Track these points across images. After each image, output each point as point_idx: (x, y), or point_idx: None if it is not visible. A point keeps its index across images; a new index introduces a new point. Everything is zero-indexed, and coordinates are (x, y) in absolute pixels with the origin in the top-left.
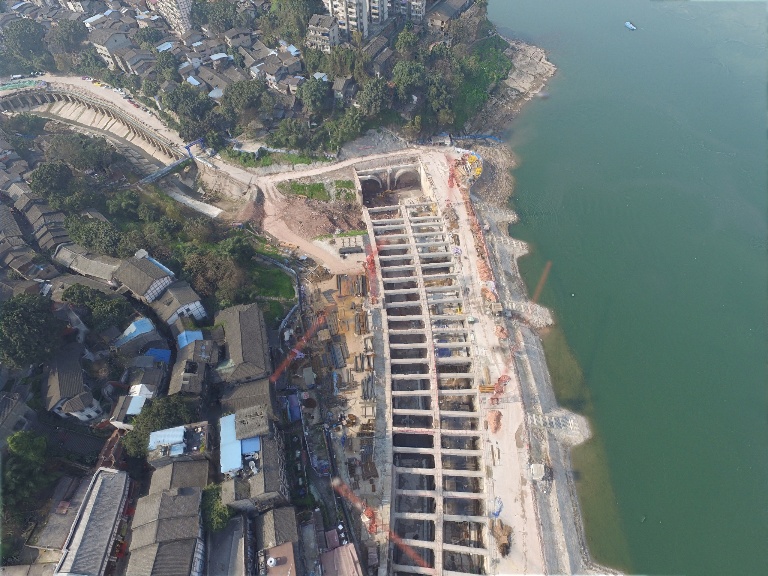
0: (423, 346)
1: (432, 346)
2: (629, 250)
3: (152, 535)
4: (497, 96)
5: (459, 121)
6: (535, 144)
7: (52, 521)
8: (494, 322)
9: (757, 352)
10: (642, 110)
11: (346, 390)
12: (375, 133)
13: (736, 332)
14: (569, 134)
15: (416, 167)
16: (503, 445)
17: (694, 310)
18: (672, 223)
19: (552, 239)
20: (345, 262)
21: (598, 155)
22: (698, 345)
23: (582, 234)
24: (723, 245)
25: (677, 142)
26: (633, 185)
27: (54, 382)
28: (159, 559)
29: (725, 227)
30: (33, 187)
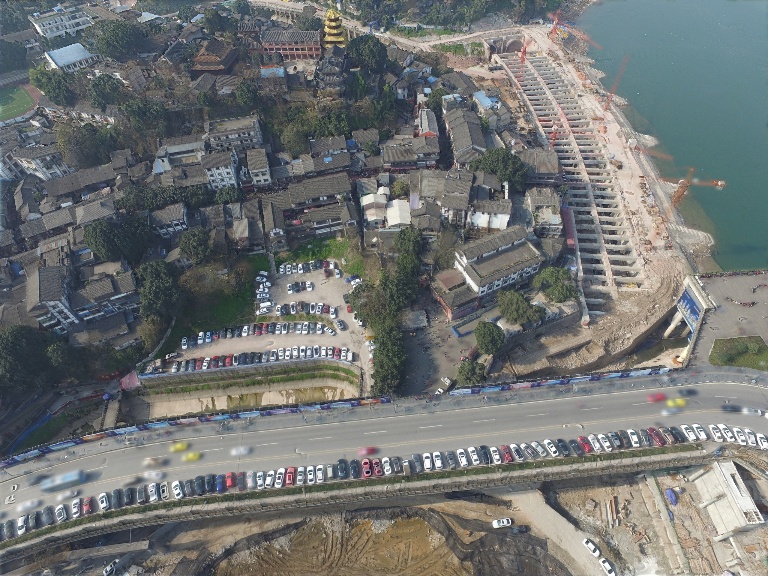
0: (552, 107)
1: (558, 105)
2: (672, 73)
3: (462, 120)
4: (568, 1)
5: (546, 12)
6: (599, 28)
7: (403, 129)
8: (593, 96)
9: (758, 110)
10: (674, 7)
11: (515, 119)
12: (493, 15)
13: (744, 104)
14: (622, 22)
15: (520, 39)
16: (610, 137)
17: (717, 96)
18: (700, 60)
19: (620, 71)
20: (493, 74)
21: (645, 31)
22: (721, 109)
23: (640, 67)
24: (735, 69)
25: (701, 22)
26: (672, 44)
27: (389, 76)
28: (469, 126)
29: (736, 61)
30: (305, 29)
